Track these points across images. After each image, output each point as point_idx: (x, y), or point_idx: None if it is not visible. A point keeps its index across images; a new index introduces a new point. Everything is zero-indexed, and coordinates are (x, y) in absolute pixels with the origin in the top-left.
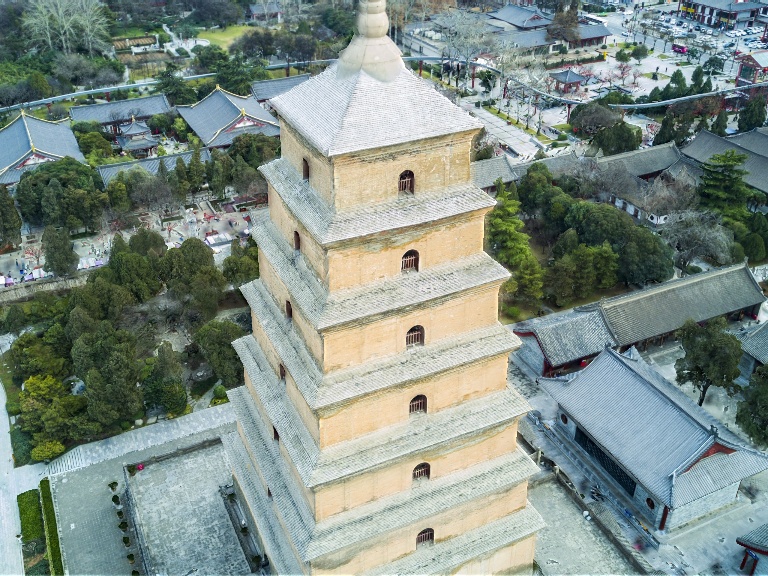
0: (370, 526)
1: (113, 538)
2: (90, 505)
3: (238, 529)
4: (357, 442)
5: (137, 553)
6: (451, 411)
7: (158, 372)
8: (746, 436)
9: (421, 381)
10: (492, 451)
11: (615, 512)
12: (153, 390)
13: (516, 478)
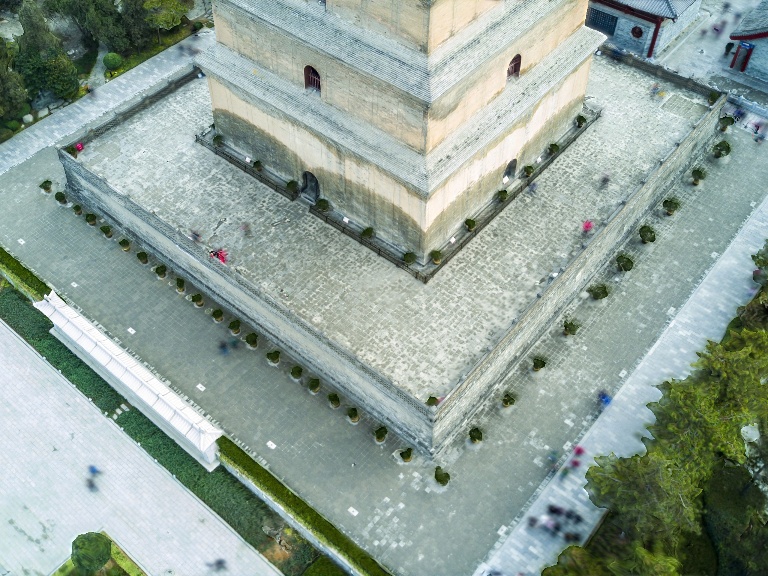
0: (480, 50)
1: (84, 236)
2: (28, 215)
3: (248, 167)
4: None
5: (126, 239)
6: None
7: (29, 46)
8: None
9: None
10: None
11: None
12: (32, 71)
13: None
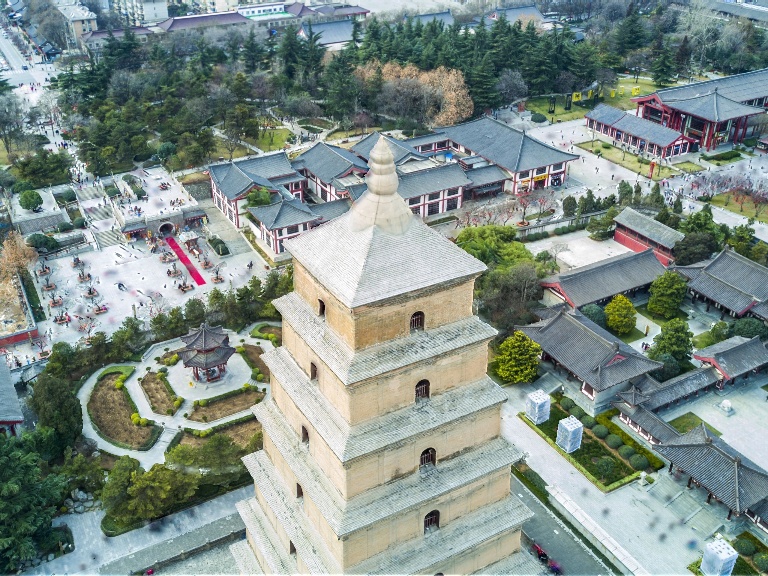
0: None
1: None
2: None
3: None
4: None
5: None
6: None
7: None
8: None
9: None
10: None
11: None
12: None
13: None
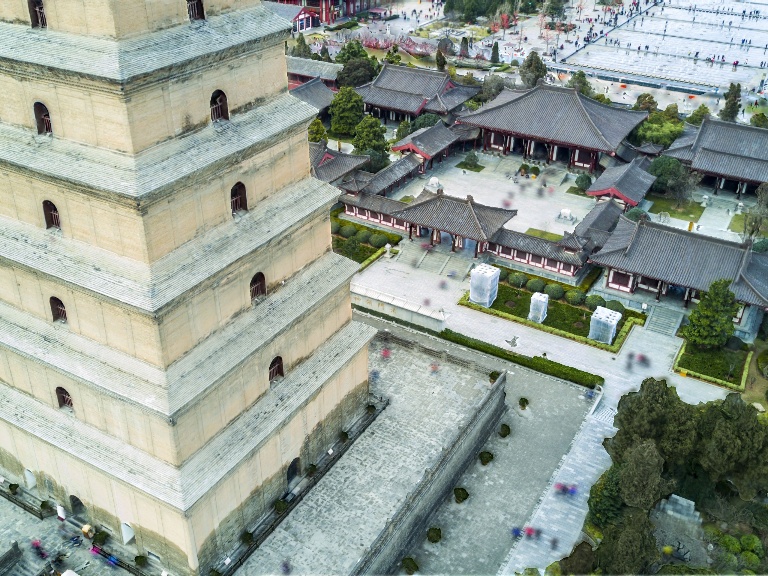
0: None
1: None
2: (524, 390)
3: None
4: None
5: None
6: None
7: None
8: None
9: None
10: None
11: None
12: None
13: None
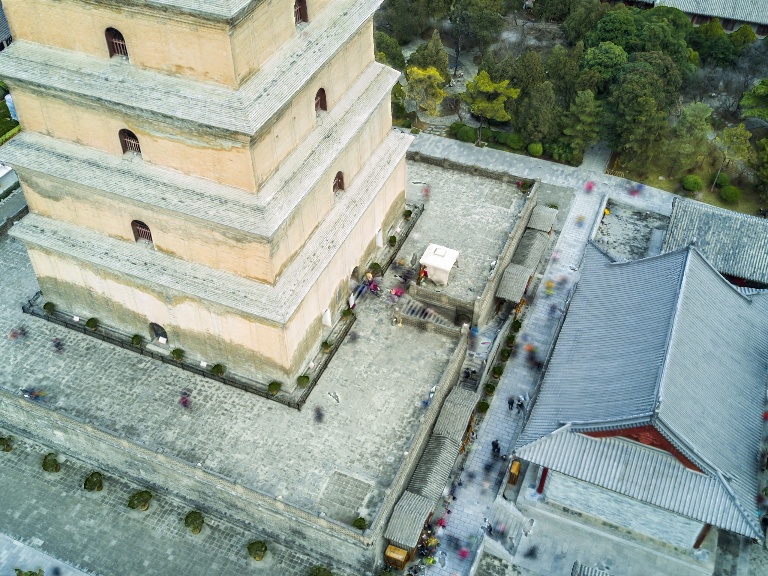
0: (63, 166)
1: None
2: None
3: None
4: (50, 52)
5: None
6: (159, 78)
7: None
8: (767, 478)
9: (107, 5)
10: (220, 172)
11: (511, 433)
12: None
13: (233, 223)
